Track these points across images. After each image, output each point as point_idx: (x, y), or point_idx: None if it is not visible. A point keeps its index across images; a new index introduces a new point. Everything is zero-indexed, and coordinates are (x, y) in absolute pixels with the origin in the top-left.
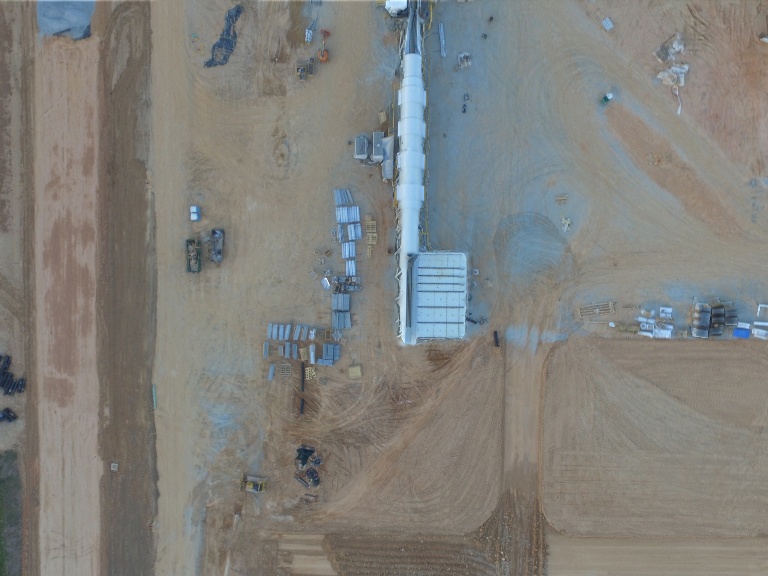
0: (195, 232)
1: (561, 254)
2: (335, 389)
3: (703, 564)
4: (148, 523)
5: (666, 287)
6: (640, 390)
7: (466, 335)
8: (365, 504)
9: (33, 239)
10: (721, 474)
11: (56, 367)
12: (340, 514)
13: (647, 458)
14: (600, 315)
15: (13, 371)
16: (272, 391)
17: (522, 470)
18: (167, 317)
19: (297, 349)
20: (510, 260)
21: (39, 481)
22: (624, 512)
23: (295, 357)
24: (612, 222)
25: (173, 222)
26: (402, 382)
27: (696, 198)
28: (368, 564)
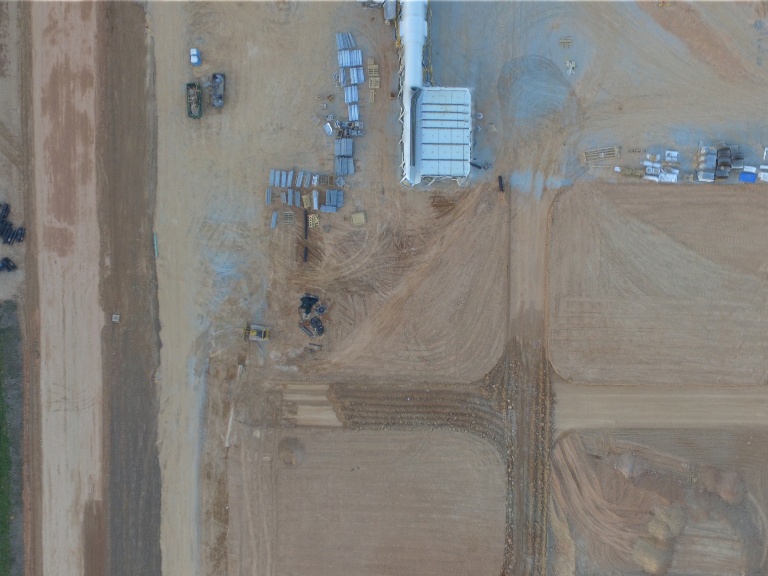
0: (195, 77)
1: (566, 98)
2: (339, 237)
3: (711, 412)
4: (151, 374)
5: (672, 131)
6: (646, 236)
7: (470, 181)
8: (370, 353)
9: (31, 85)
10: (728, 321)
11: (56, 216)
12: (345, 364)
13: (654, 305)
14: (605, 160)
15: (12, 220)
16: (275, 239)
17: (528, 318)
18: (168, 164)
19: (300, 196)
20: (514, 104)
21: (39, 333)
22: (631, 359)
23: (298, 204)
24: (617, 65)
25: (173, 67)
26: (406, 229)
27: (701, 40)
28: (374, 413)
